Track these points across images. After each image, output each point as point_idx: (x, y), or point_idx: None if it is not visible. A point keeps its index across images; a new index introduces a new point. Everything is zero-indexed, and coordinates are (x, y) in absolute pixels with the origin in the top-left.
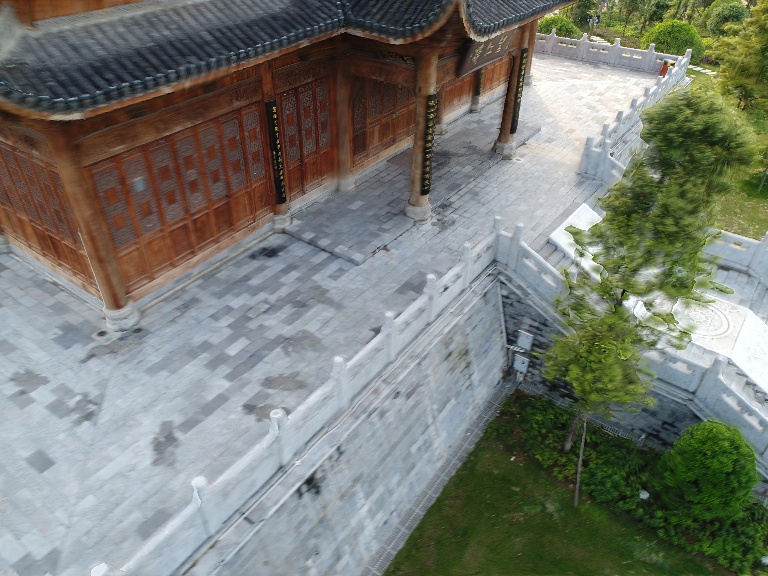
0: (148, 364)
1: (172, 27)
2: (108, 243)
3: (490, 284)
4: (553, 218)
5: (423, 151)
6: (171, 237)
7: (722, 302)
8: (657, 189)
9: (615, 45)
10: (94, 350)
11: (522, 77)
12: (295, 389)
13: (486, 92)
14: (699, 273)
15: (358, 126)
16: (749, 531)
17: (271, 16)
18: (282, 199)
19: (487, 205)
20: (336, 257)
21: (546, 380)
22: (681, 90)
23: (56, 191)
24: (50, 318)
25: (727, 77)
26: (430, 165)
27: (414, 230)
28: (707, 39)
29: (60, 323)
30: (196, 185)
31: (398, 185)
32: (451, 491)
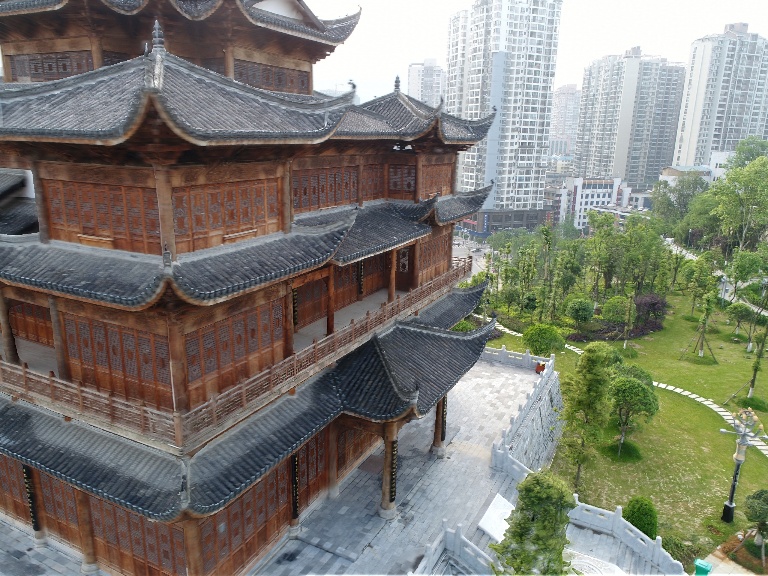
0: None
1: (255, 436)
2: (202, 572)
3: (445, 568)
4: (479, 508)
5: (390, 474)
6: (233, 559)
7: (598, 561)
8: (532, 525)
9: (502, 350)
10: None
11: (445, 405)
12: None
13: None
14: (564, 565)
15: (340, 451)
16: None
17: (303, 413)
18: (296, 515)
19: (433, 501)
20: (337, 557)
21: None
22: (534, 474)
23: (172, 540)
24: None
25: (572, 404)
26: (395, 482)
27: (387, 528)
28: (569, 318)
29: None
30: (250, 519)
31: (369, 489)
32: None
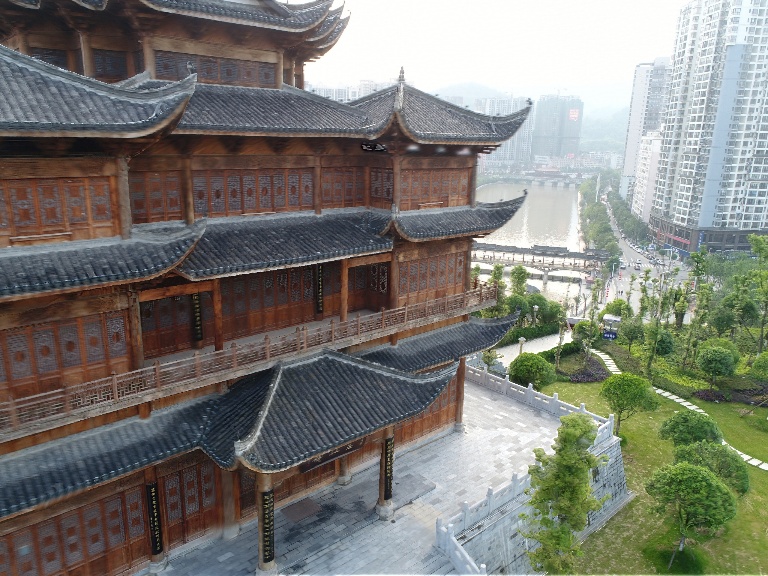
0: None
1: (58, 459)
2: None
3: None
4: None
5: (263, 530)
6: None
7: None
8: None
9: (553, 398)
10: None
11: (389, 458)
12: None
13: (405, 443)
14: None
15: (246, 488)
16: None
17: (141, 442)
18: (157, 551)
19: (332, 572)
20: None
21: None
22: None
23: None
24: None
25: None
26: (270, 540)
27: None
28: None
29: None
30: (76, 546)
31: None
32: None
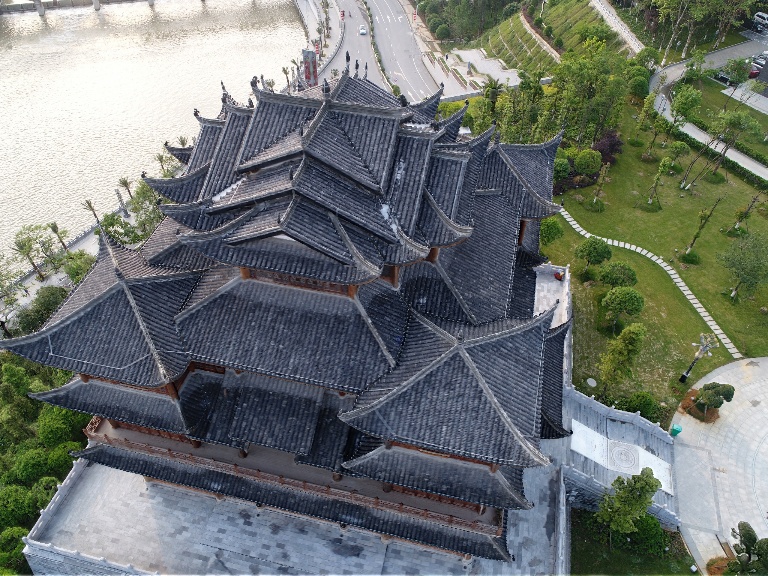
0: (491, 574)
1: None
2: None
3: None
4: None
5: None
6: None
7: (629, 445)
8: (640, 499)
9: None
10: (470, 575)
11: None
12: (540, 564)
13: None
14: None
15: None
16: (660, 541)
17: None
18: None
19: None
20: None
21: (581, 501)
22: (644, 479)
23: None
24: (441, 568)
25: None
26: None
27: None
28: None
29: (447, 569)
30: None
31: None
32: (573, 562)
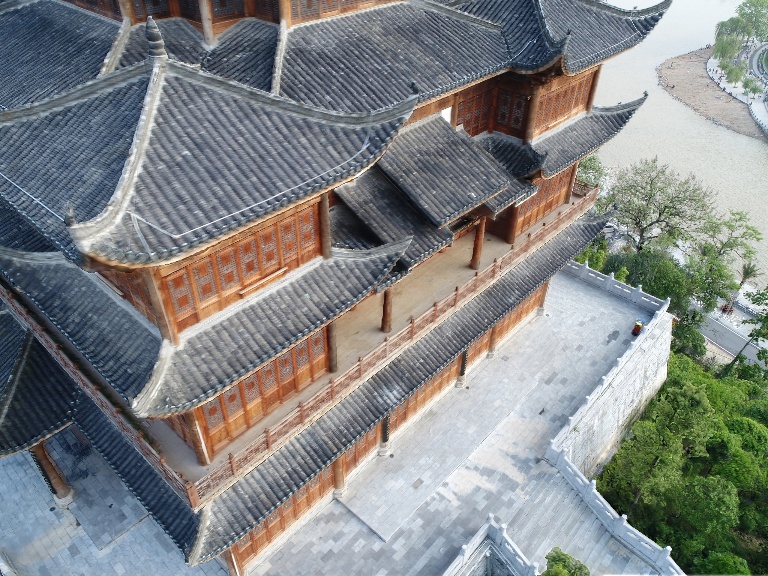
0: None
1: None
2: None
3: None
4: None
5: None
6: None
7: None
8: None
9: None
10: None
11: None
12: None
13: None
14: None
15: None
16: None
17: None
18: None
19: (2, 467)
20: None
21: None
22: None
23: None
24: None
25: None
26: None
27: None
28: None
29: None
30: None
31: None
32: None
